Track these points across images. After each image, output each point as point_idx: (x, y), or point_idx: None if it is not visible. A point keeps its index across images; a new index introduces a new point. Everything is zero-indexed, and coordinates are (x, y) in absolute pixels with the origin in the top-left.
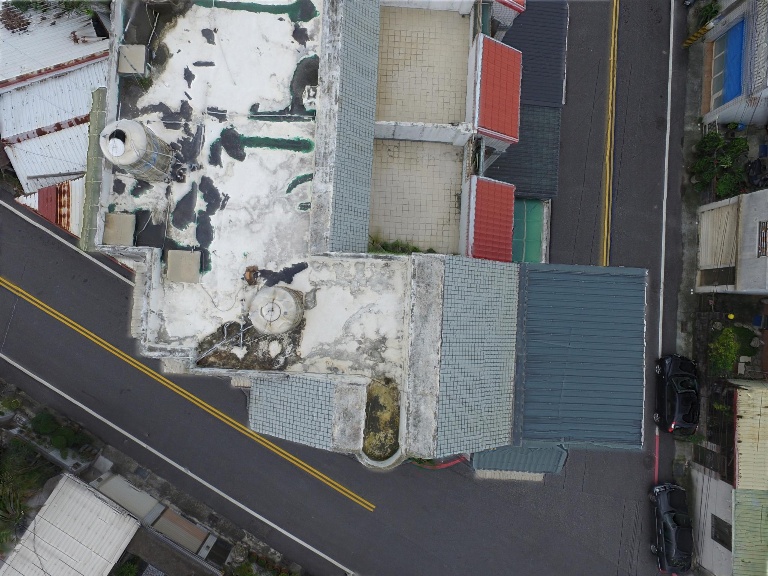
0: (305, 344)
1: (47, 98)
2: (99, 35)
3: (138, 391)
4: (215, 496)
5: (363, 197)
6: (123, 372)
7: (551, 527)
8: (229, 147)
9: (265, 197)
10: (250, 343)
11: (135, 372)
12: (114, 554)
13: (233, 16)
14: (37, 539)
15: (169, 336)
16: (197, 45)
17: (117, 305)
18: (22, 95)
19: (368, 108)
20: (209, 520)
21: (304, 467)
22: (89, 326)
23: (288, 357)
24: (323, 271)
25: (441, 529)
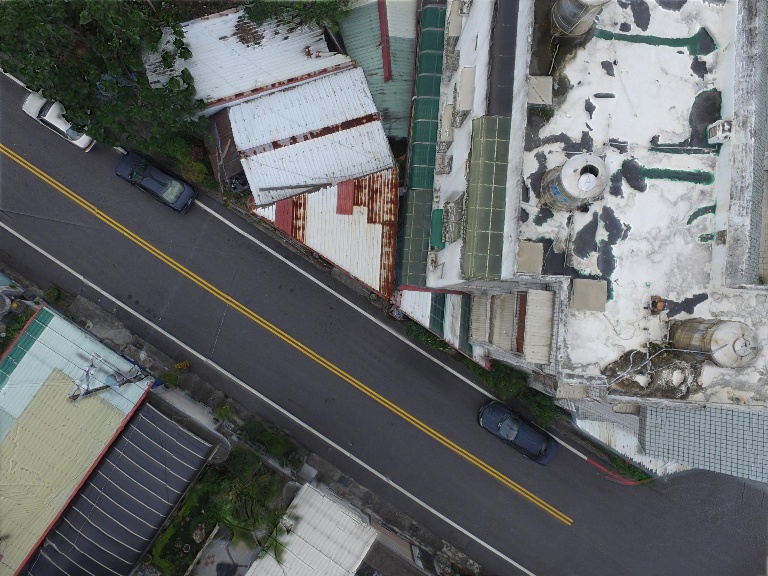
0: (707, 374)
1: (278, 111)
2: (331, 50)
3: (342, 400)
4: (416, 506)
5: (759, 229)
6: (328, 381)
7: (748, 546)
8: (630, 178)
9: (666, 228)
10: (654, 372)
11: (340, 382)
12: (353, 563)
13: (632, 49)
14: (279, 546)
15: (572, 363)
16: (597, 77)
17: (322, 315)
18: (252, 108)
19: (763, 141)
20: (409, 530)
21: (504, 480)
22: (295, 335)
23: (690, 386)
24: (724, 302)
25: (639, 545)
